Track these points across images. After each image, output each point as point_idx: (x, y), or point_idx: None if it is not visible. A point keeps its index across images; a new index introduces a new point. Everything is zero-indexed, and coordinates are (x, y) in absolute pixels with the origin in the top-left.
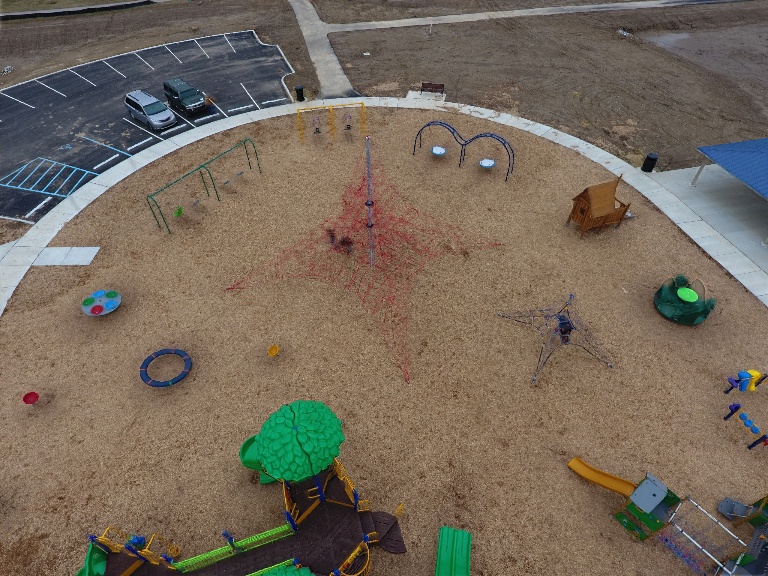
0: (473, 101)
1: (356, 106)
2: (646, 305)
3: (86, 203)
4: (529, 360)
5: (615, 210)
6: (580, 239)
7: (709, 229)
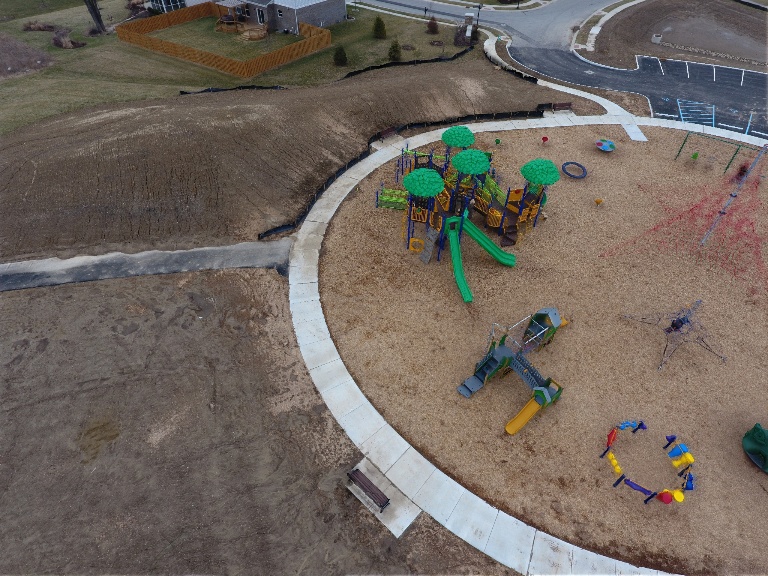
0: None
1: None
2: None
3: (682, 128)
4: None
5: None
6: None
7: None
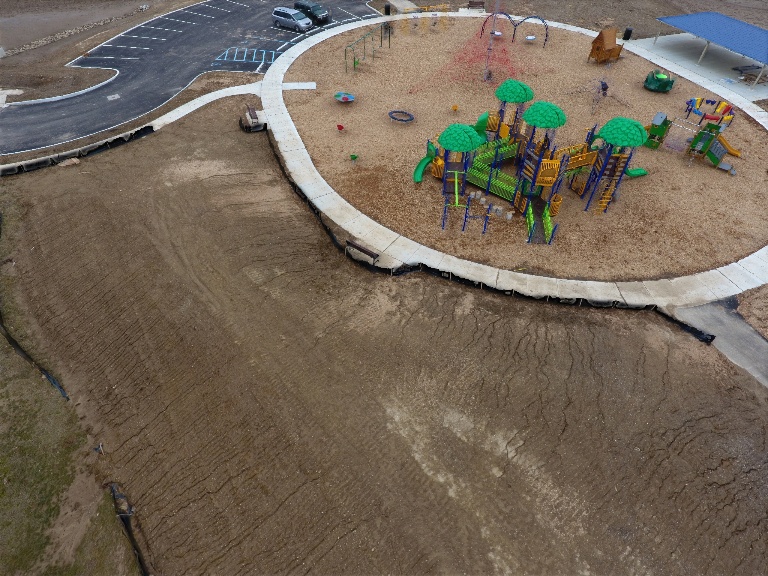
0: (505, 12)
1: (428, 17)
2: (640, 89)
3: (288, 65)
4: (587, 107)
5: (616, 47)
6: (597, 67)
7: (667, 61)
